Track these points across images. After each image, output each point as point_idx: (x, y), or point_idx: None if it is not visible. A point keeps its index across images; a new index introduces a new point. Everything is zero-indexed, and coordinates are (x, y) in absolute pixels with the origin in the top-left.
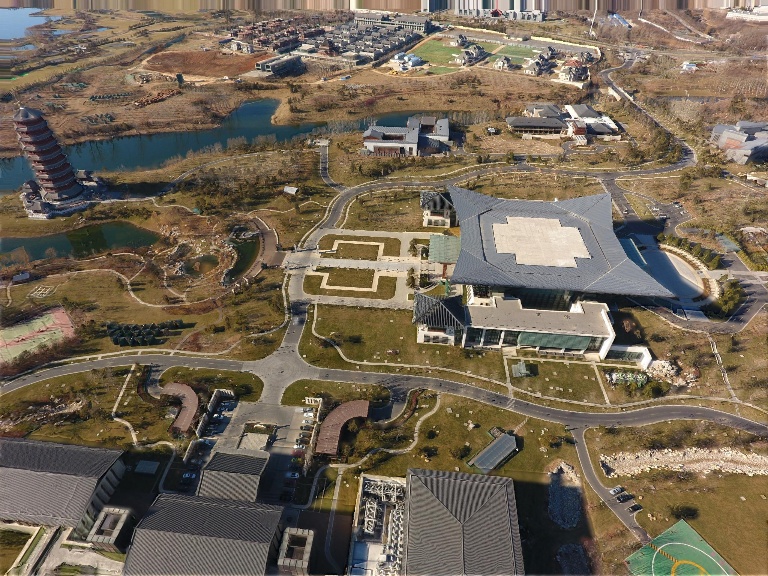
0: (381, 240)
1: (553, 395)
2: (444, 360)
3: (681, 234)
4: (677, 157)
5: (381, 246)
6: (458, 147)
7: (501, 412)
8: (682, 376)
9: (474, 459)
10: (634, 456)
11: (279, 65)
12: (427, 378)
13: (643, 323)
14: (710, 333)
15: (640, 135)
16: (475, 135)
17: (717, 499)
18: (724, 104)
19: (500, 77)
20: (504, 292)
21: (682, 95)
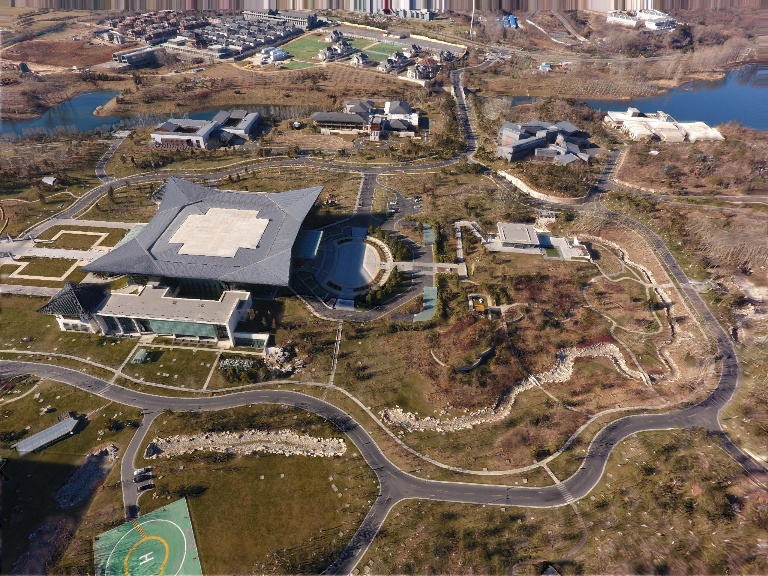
0: (108, 231)
1: (154, 381)
2: (74, 347)
3: (397, 227)
4: (452, 154)
5: (103, 236)
6: (254, 141)
7: (88, 397)
8: (292, 362)
9: (19, 442)
10: (188, 438)
11: (137, 56)
12: (42, 365)
13: (287, 312)
14: (344, 321)
15: (437, 132)
16: (276, 129)
17: (236, 478)
18: (540, 104)
19: (350, 73)
20: (159, 281)
21: (522, 95)
